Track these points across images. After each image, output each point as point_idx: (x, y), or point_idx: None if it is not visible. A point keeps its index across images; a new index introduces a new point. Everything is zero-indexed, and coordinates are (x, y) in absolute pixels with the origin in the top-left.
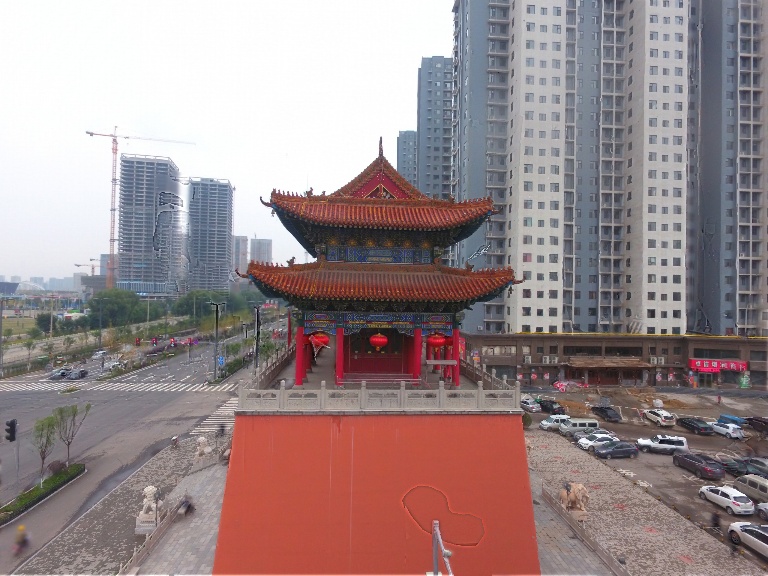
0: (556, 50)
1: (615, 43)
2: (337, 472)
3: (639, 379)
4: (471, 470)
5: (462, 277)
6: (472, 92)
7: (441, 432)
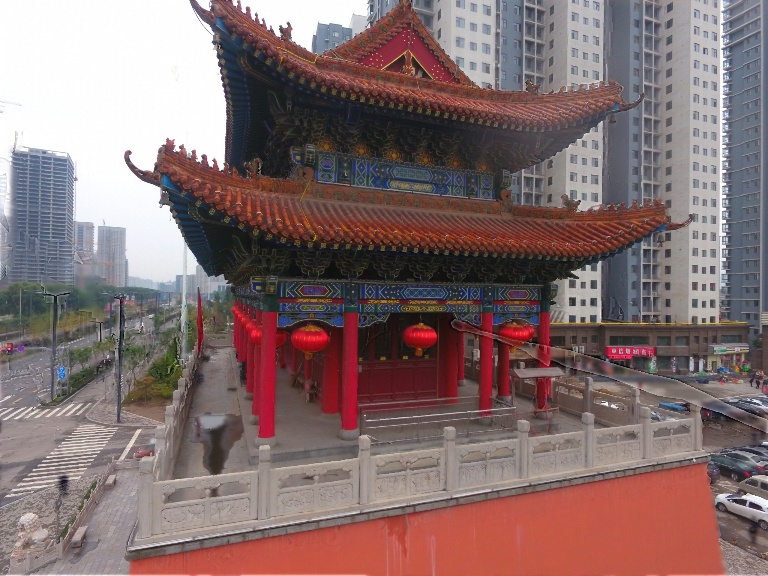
0: (486, 14)
1: (536, 21)
2: None
3: (562, 369)
4: None
5: (558, 221)
6: None
7: (593, 517)
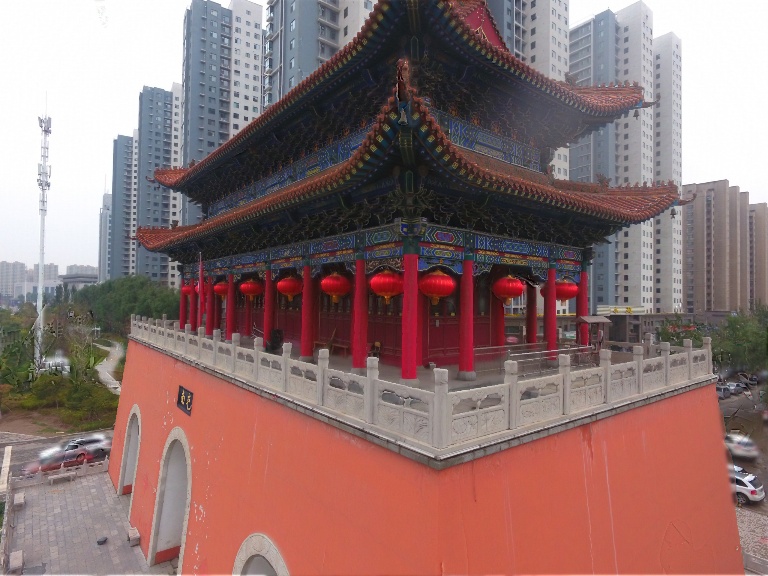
0: None
1: None
2: (598, 543)
3: None
4: (697, 475)
5: (595, 195)
6: (302, 39)
7: (674, 424)
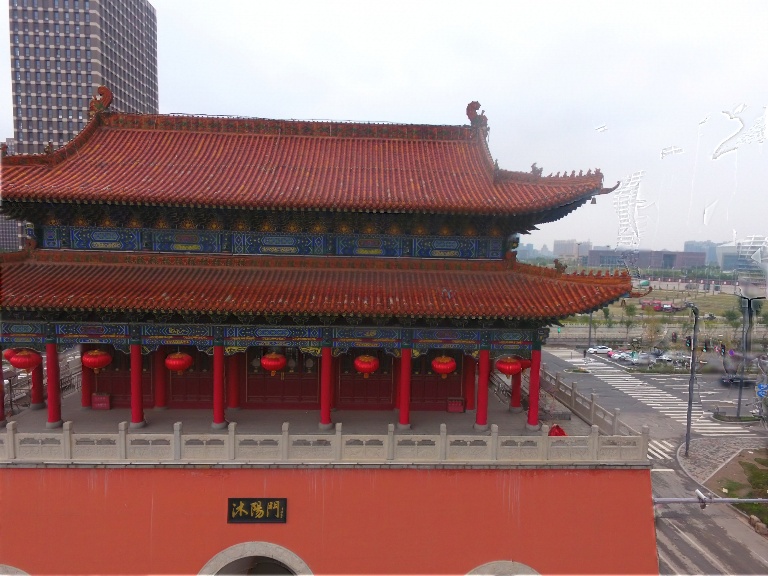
0: None
1: None
2: None
3: None
4: None
5: None
6: None
7: None
